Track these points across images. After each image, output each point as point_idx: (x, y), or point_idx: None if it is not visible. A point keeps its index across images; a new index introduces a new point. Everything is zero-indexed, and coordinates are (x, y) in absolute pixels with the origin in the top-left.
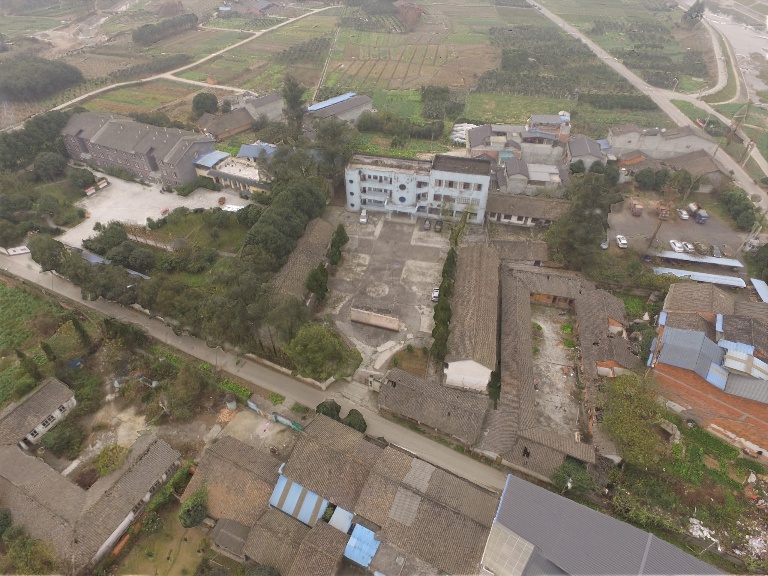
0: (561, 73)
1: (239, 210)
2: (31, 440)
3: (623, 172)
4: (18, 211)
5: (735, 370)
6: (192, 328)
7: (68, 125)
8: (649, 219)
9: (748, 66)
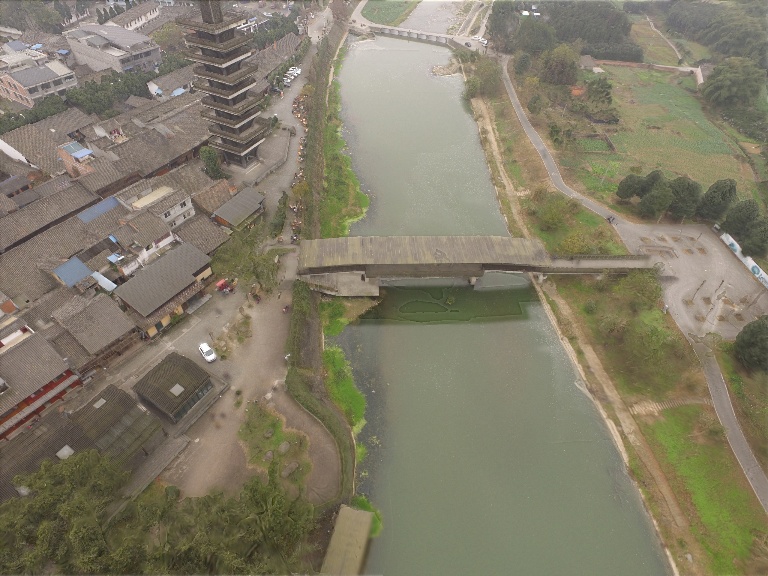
0: None
1: None
2: None
3: None
4: None
5: None
6: None
7: None
8: None
9: None
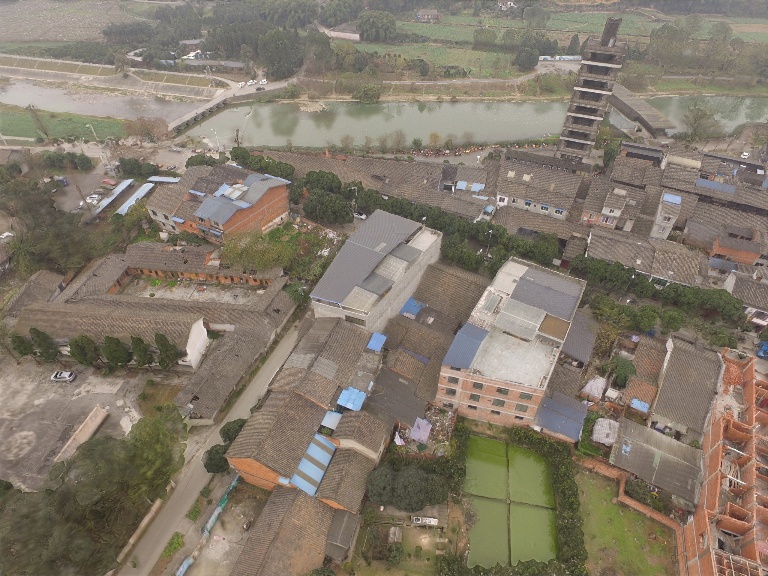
0: None
1: None
2: None
3: None
4: None
5: (239, 196)
6: None
7: None
8: None
9: None
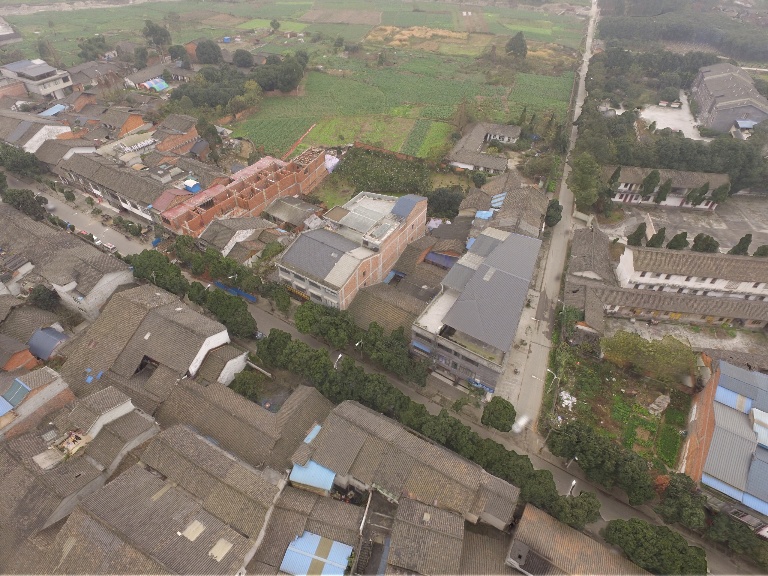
0: None
1: None
2: (491, 138)
3: None
4: (619, 89)
5: None
6: None
7: None
8: None
9: None
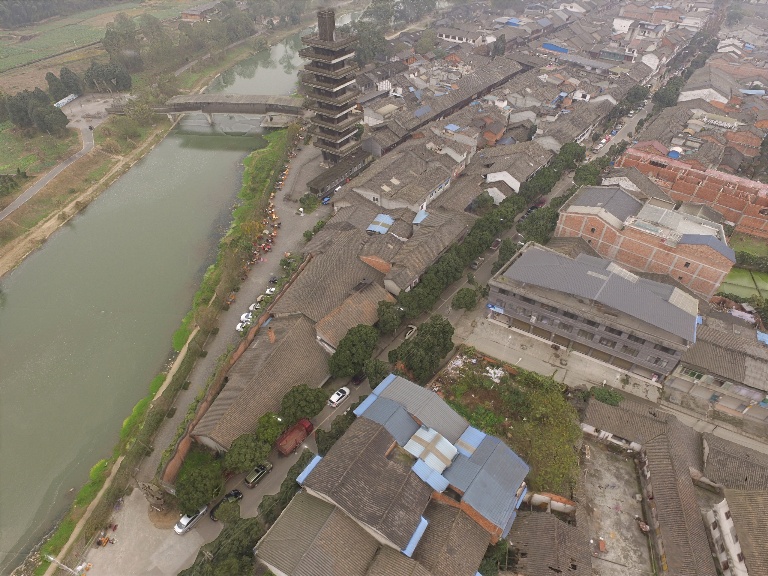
0: None
1: None
2: None
3: None
4: None
5: None
6: None
7: None
8: None
9: None
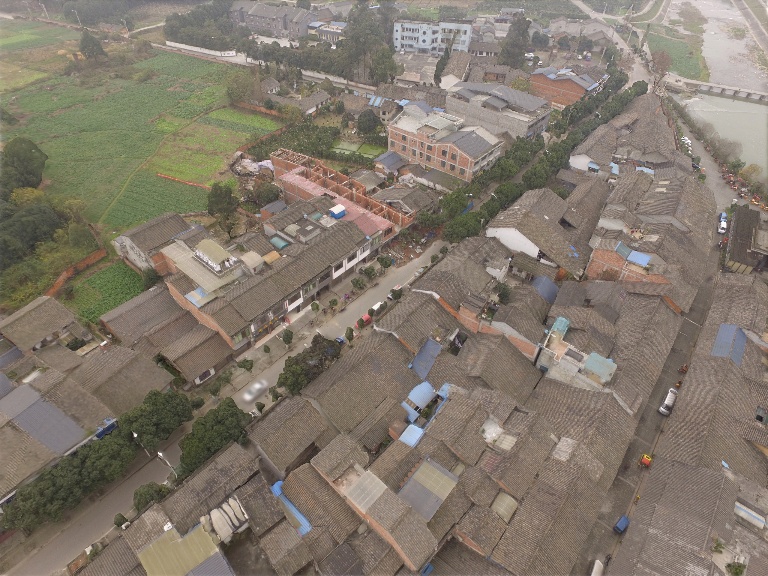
0: (536, 4)
1: (338, 41)
2: None
3: (551, 39)
4: None
5: (560, 74)
6: (328, 66)
7: (233, 5)
8: (560, 59)
9: (675, 8)
